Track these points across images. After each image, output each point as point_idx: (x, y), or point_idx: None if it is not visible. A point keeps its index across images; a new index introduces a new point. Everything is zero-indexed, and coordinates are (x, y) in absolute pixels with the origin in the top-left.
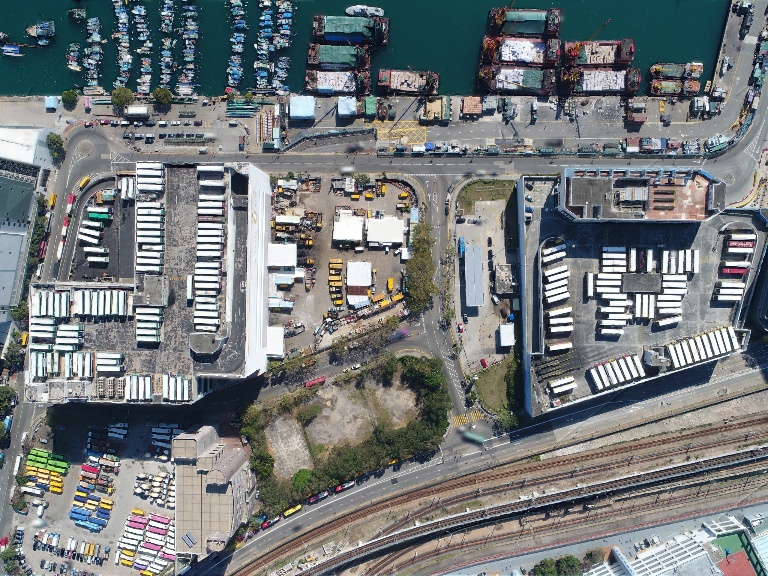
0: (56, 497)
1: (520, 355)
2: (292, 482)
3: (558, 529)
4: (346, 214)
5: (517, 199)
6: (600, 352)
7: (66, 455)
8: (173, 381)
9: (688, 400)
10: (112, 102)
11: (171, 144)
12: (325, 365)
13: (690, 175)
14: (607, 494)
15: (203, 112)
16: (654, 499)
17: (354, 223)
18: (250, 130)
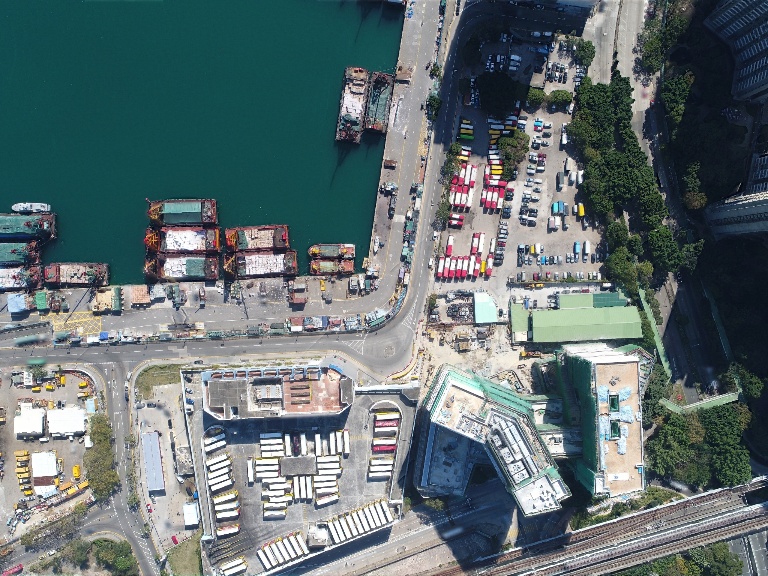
0: None
1: None
2: None
3: None
4: (27, 407)
5: None
6: (269, 531)
7: None
8: None
9: (370, 559)
10: None
11: None
12: (22, 553)
13: (319, 372)
14: None
15: None
16: None
17: (35, 416)
18: None
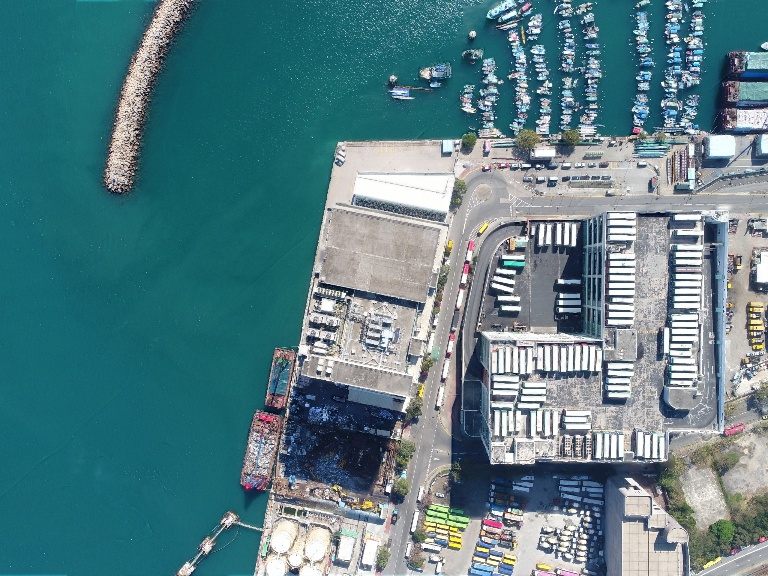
0: (453, 553)
1: None
2: (713, 534)
3: None
4: (767, 256)
5: None
6: None
7: (464, 509)
8: (649, 439)
9: None
10: (519, 145)
11: (575, 187)
12: (742, 412)
13: None
14: None
15: (609, 153)
16: None
17: None
18: (660, 171)
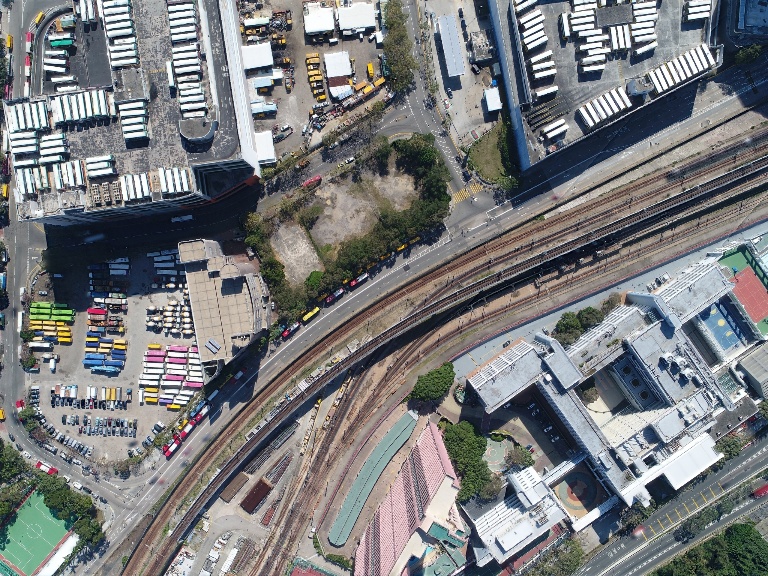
0: (66, 349)
1: (508, 119)
2: (306, 285)
3: (572, 285)
4: (314, 6)
5: None
6: (585, 93)
7: (69, 303)
8: (170, 173)
9: (675, 137)
10: None
11: None
12: (319, 164)
13: None
14: None
15: None
16: (658, 238)
17: (324, 14)
18: None
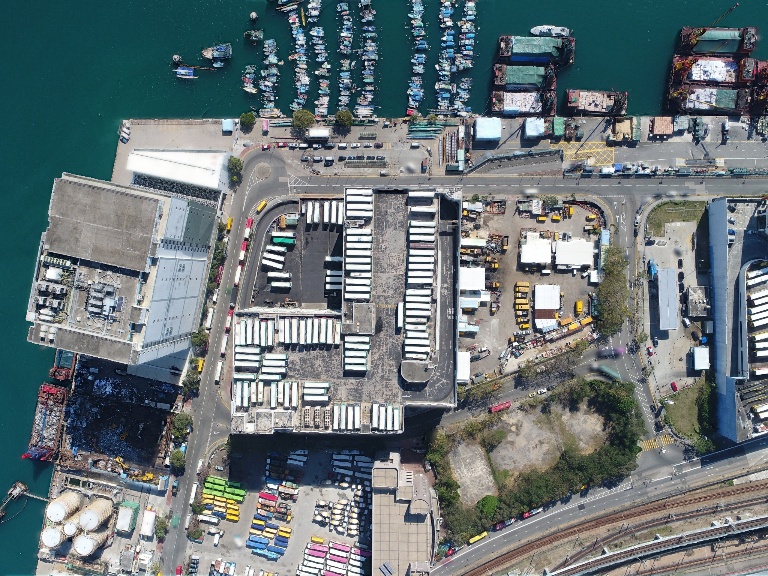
0: (232, 525)
1: (713, 378)
2: (478, 509)
3: (751, 555)
4: (533, 237)
5: (708, 220)
6: None
7: (242, 482)
8: (383, 410)
9: None
10: (293, 125)
11: (351, 167)
12: (510, 390)
13: None
14: None
15: (384, 134)
16: None
17: (542, 246)
18: (432, 152)
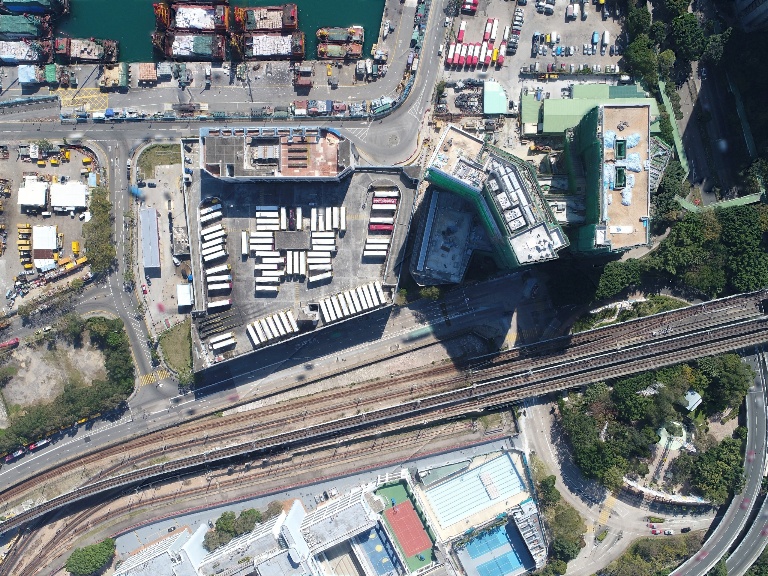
0: None
1: None
2: None
3: (242, 483)
4: (31, 180)
5: None
6: (260, 309)
7: None
8: None
9: (362, 356)
10: None
11: None
12: (19, 328)
13: (318, 133)
14: (284, 448)
15: None
16: (332, 453)
17: (38, 188)
18: None
